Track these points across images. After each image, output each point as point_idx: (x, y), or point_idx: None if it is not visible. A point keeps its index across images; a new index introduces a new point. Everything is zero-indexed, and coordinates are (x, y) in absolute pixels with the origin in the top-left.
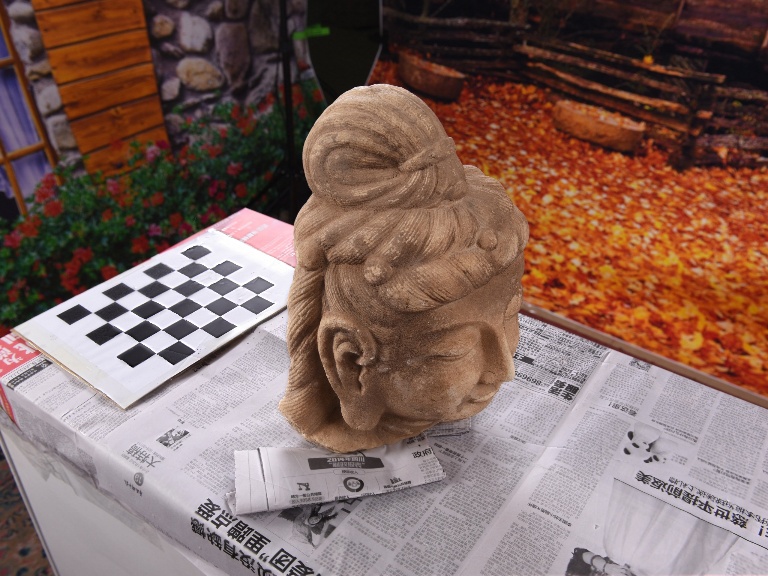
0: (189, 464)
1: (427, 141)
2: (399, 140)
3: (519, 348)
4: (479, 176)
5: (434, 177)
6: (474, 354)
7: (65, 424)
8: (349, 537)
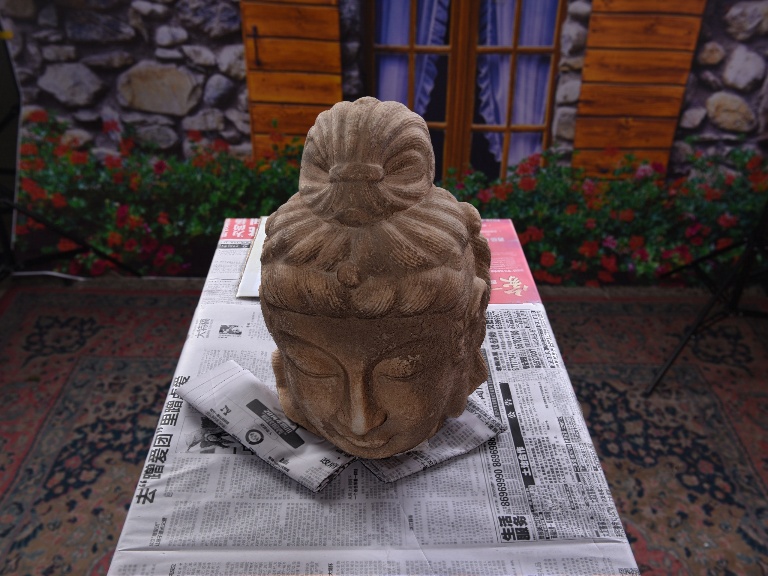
0: (213, 350)
1: (343, 158)
2: (329, 148)
3: (538, 465)
4: (417, 222)
5: (335, 194)
6: (334, 384)
7: (205, 284)
8: (210, 465)
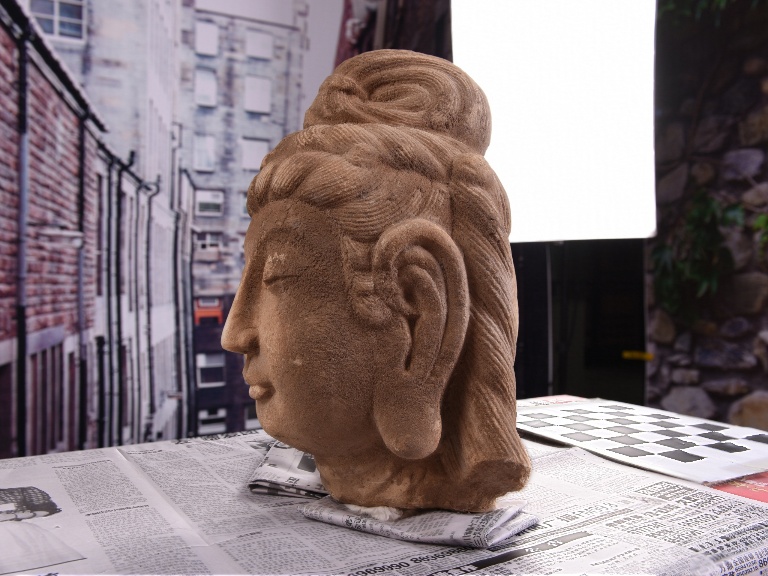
0: None
1: None
2: None
3: None
4: None
5: None
6: None
7: None
8: (239, 450)
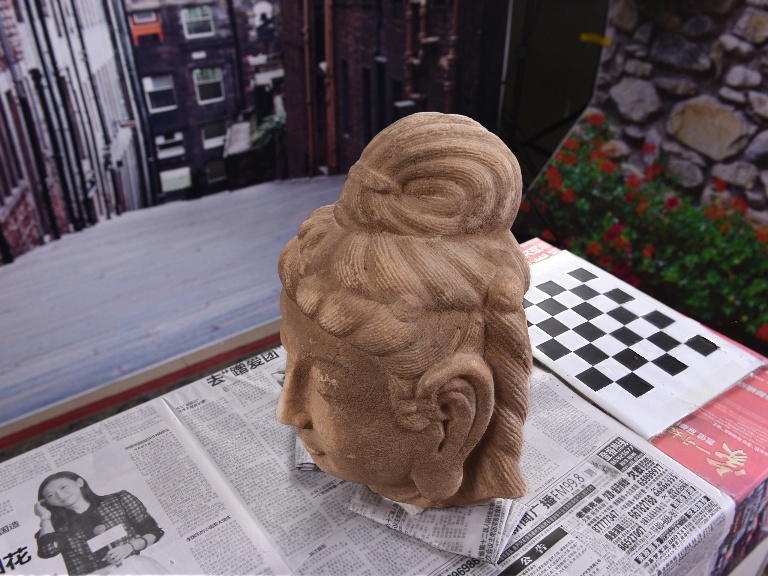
0: None
1: None
2: None
3: None
4: (391, 250)
5: None
6: None
7: None
8: (270, 392)
